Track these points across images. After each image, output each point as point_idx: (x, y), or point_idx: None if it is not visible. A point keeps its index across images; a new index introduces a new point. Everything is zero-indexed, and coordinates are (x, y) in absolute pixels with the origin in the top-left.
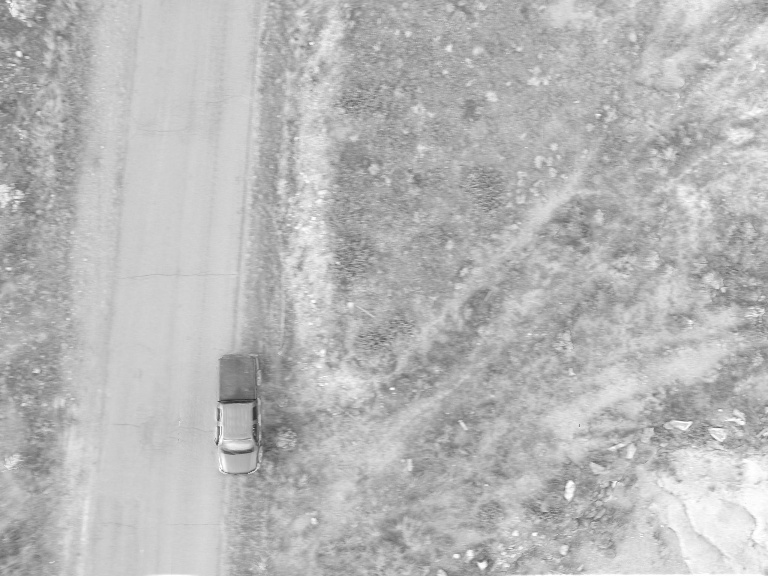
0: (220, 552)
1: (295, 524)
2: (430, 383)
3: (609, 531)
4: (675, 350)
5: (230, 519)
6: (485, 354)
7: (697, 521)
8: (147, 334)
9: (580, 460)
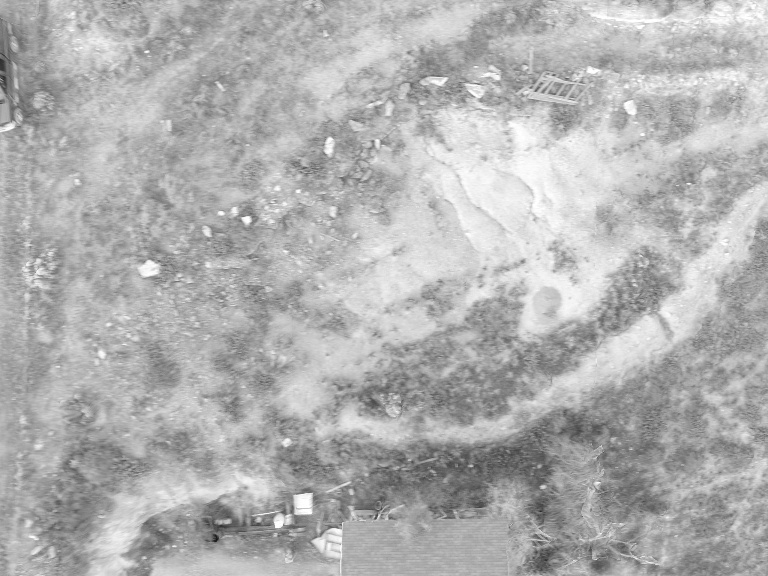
0: None
1: (59, 186)
2: (184, 45)
3: (379, 195)
4: (427, 10)
5: None
6: (238, 17)
7: (473, 192)
8: None
9: (340, 119)
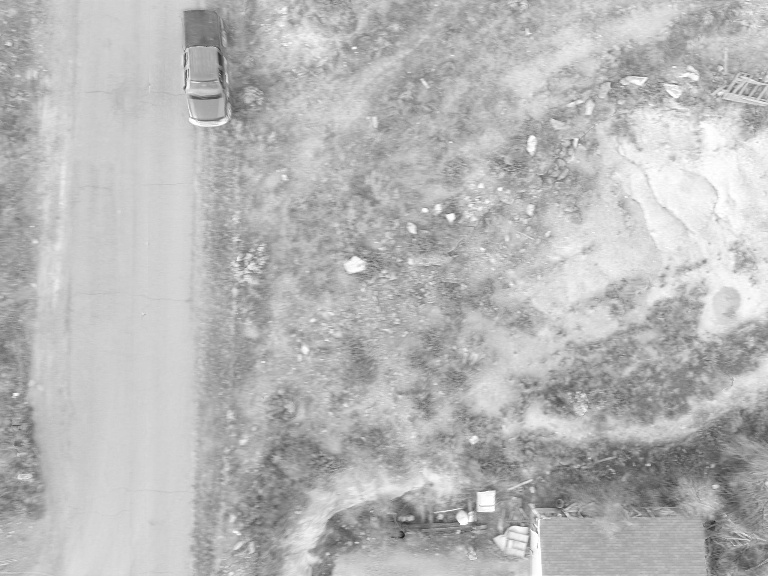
0: (195, 210)
1: (266, 181)
2: (391, 41)
3: (573, 194)
4: (627, 9)
5: (203, 177)
6: (443, 14)
7: (660, 192)
8: (114, 5)
9: (541, 117)
